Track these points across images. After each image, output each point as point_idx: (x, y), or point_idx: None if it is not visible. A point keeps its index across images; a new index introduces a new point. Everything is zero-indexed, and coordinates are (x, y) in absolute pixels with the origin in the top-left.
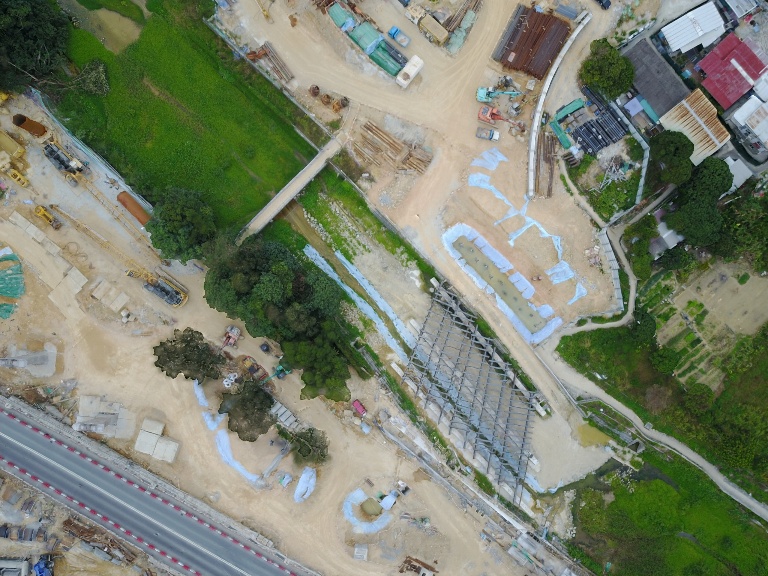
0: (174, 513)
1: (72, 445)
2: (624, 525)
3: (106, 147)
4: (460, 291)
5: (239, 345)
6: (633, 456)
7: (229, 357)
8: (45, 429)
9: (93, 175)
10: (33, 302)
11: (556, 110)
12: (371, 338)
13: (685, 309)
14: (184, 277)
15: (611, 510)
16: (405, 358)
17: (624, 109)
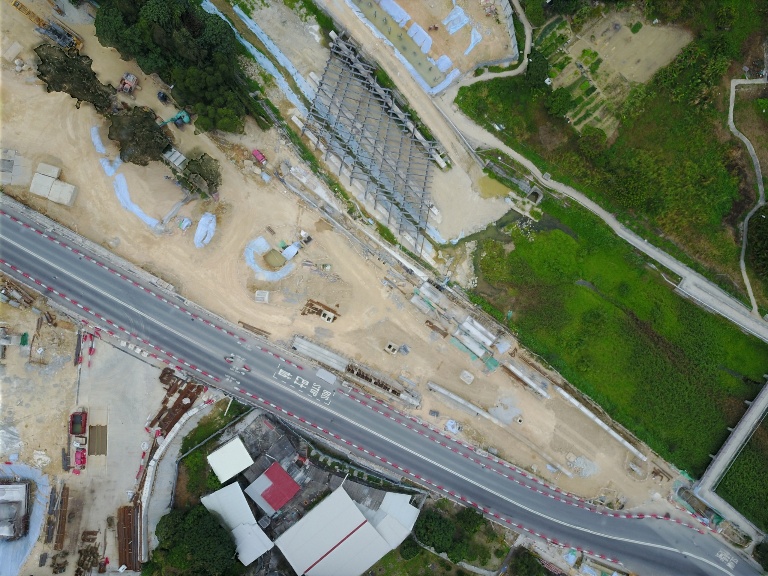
0: (72, 257)
1: None
2: (524, 272)
3: None
4: (357, 40)
5: (137, 96)
6: (532, 207)
7: (127, 107)
8: None
9: None
10: None
11: None
12: (271, 93)
13: (580, 58)
14: (79, 28)
15: (511, 258)
16: (306, 112)
17: None
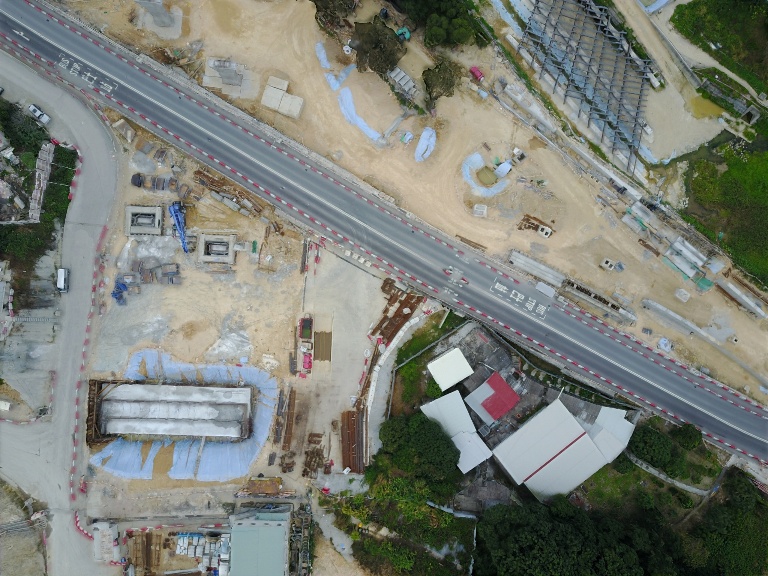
0: (299, 168)
1: (200, 101)
2: (737, 193)
3: None
4: None
5: (358, 14)
6: (746, 127)
7: (348, 24)
8: (174, 85)
9: None
10: None
11: None
12: (486, 12)
13: None
14: None
15: (724, 178)
16: (519, 31)
17: None
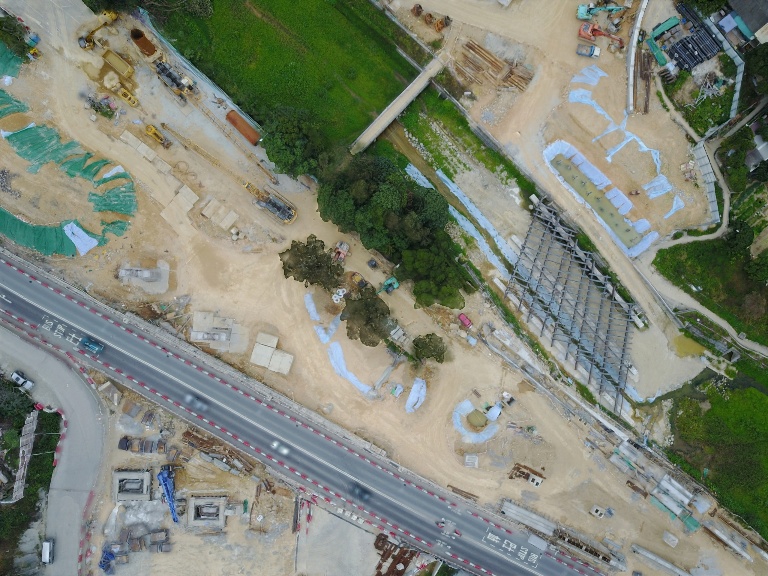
0: (289, 424)
1: (188, 359)
2: (721, 431)
3: (214, 67)
4: (561, 206)
5: (346, 262)
6: (727, 365)
7: (337, 273)
8: (161, 344)
9: (201, 95)
10: (145, 220)
11: (652, 28)
12: (473, 255)
13: None
14: (291, 195)
15: (708, 417)
16: (506, 274)
17: (718, 26)
